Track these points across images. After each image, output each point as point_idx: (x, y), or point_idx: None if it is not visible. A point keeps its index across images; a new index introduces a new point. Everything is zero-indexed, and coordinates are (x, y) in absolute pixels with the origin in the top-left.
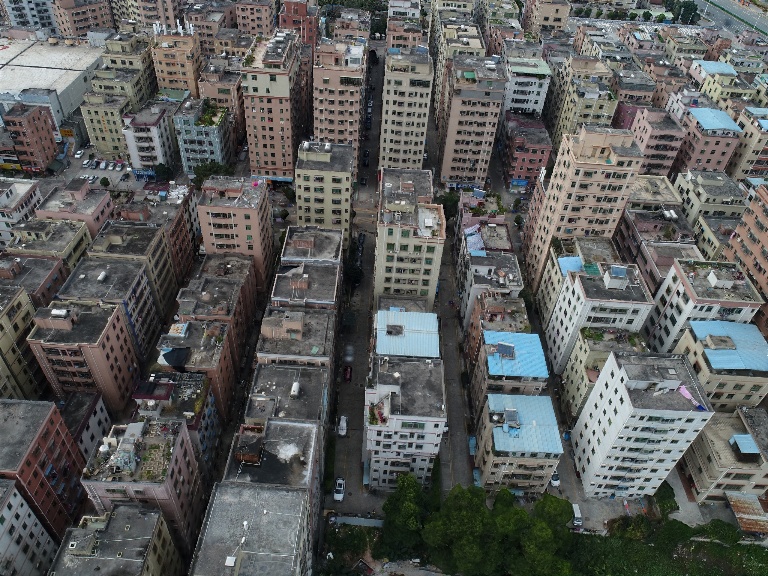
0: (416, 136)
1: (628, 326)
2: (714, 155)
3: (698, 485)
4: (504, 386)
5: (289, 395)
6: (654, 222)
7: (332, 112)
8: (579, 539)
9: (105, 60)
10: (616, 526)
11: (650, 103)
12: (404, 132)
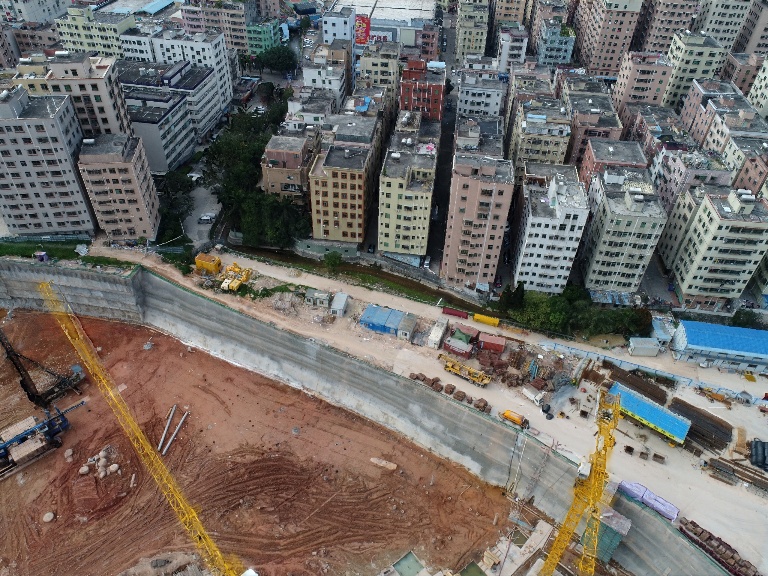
0: (728, 41)
1: None
2: None
3: None
4: None
5: (762, 149)
6: None
7: (670, 22)
8: None
9: None
10: None
11: None
12: (719, 38)
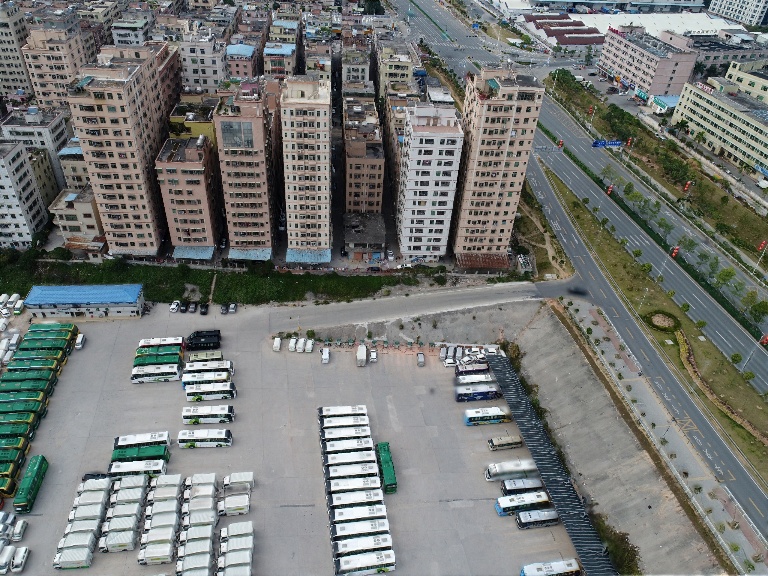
0: (16, 67)
1: (44, 147)
2: (240, 75)
3: None
4: None
5: None
6: None
7: None
8: None
9: None
10: None
11: None
12: (6, 64)
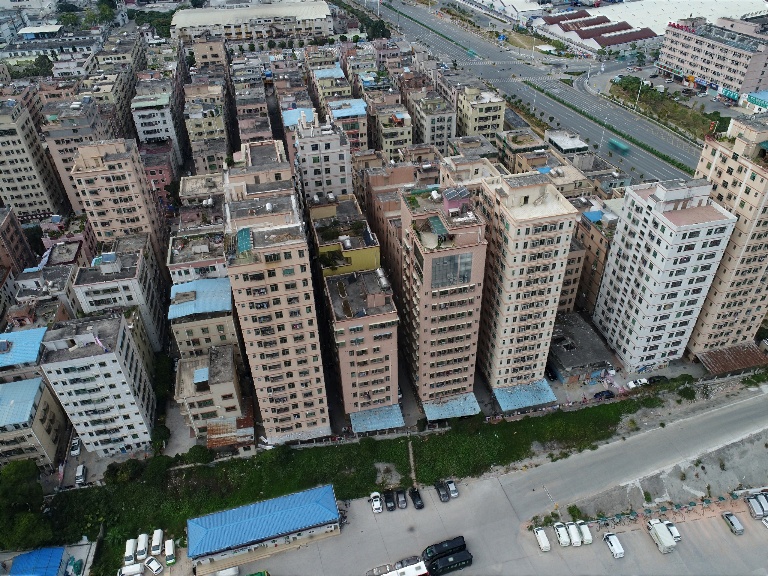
0: (29, 180)
1: (132, 302)
2: None
3: (184, 421)
4: (4, 378)
5: None
6: (193, 211)
7: None
8: (72, 494)
9: None
10: (105, 474)
11: (265, 113)
12: (16, 179)
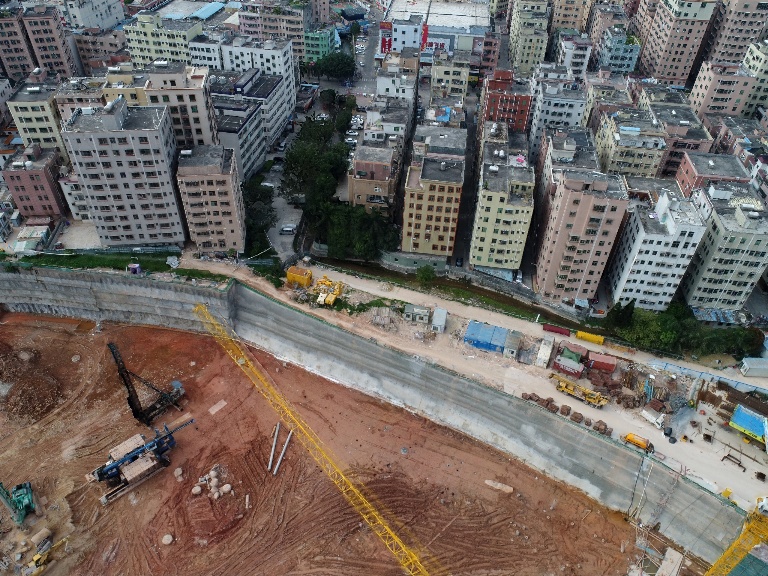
0: None
1: None
2: None
3: None
4: None
5: None
6: None
7: (740, 31)
8: None
9: (520, 6)
10: None
11: None
12: None
